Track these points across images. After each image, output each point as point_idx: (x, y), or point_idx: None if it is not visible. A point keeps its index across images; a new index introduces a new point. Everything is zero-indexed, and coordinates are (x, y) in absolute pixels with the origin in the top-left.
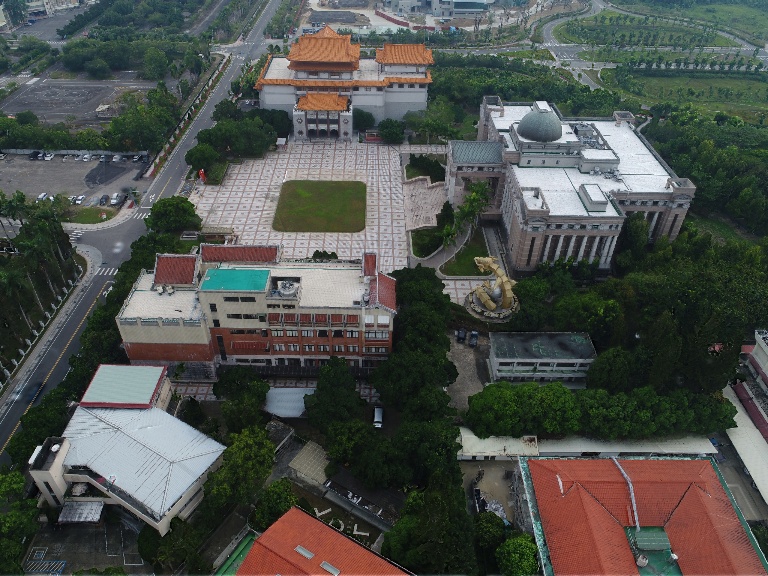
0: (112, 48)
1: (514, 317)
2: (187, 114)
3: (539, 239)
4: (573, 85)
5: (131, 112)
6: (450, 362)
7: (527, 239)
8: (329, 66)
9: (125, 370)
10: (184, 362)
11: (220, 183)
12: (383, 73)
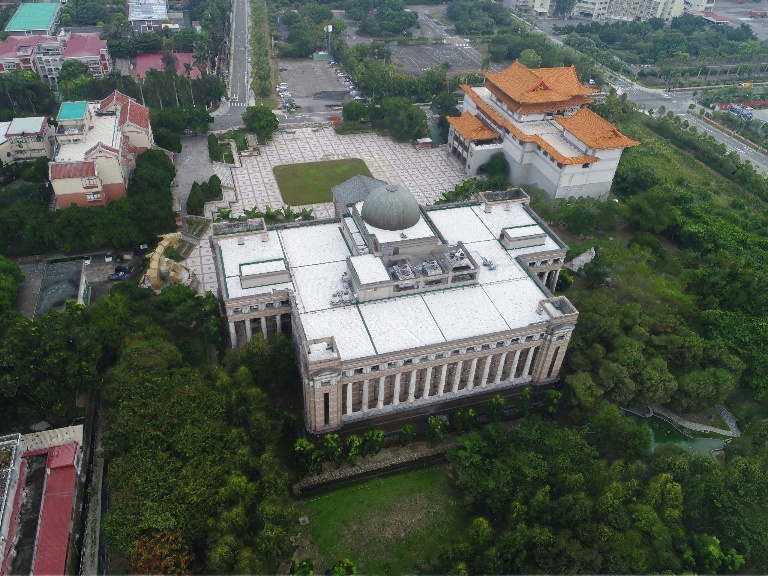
0: (522, 42)
1: None
2: (459, 101)
3: None
4: None
5: None
6: (37, 237)
7: None
8: (508, 98)
9: (38, 123)
10: None
11: (340, 134)
12: (558, 135)
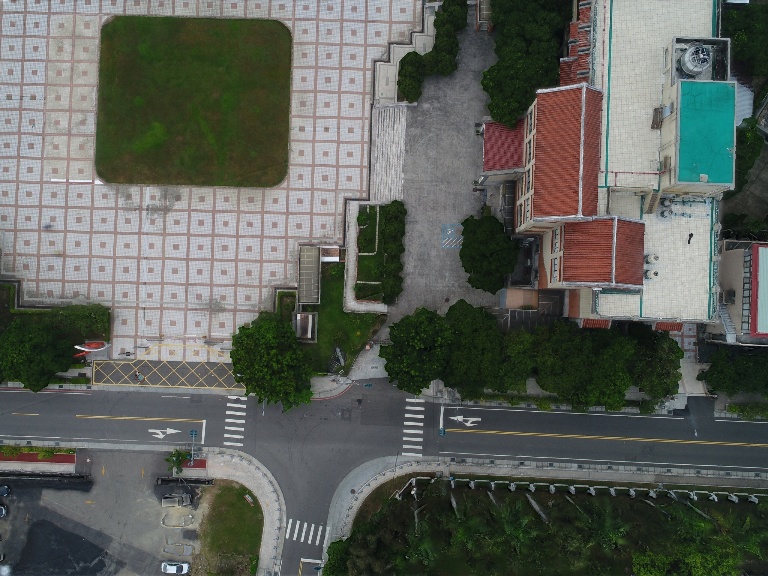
0: None
1: None
2: None
3: None
4: None
5: None
6: None
7: None
8: None
9: (767, 297)
10: (753, 221)
11: None
12: None
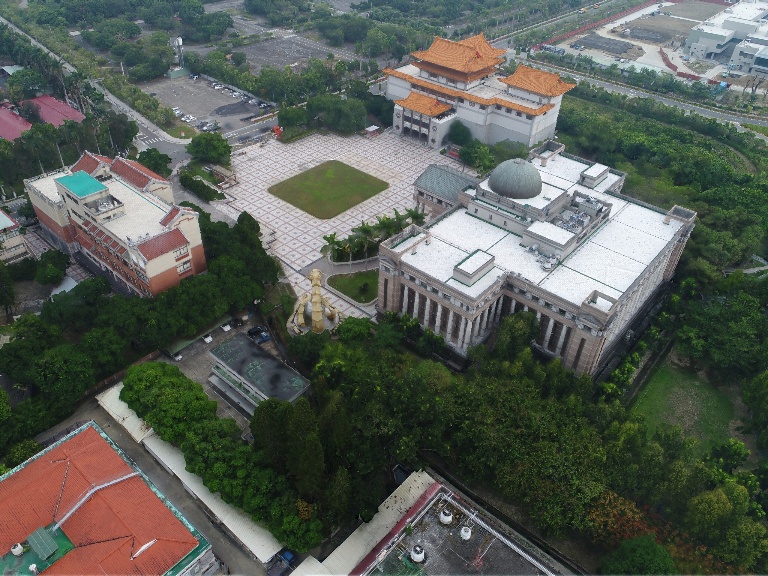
0: (354, 23)
1: (294, 337)
2: None
3: (391, 283)
4: (750, 176)
5: (302, 72)
6: (167, 329)
7: (381, 277)
8: (447, 71)
9: None
10: None
11: (288, 143)
12: (504, 94)
